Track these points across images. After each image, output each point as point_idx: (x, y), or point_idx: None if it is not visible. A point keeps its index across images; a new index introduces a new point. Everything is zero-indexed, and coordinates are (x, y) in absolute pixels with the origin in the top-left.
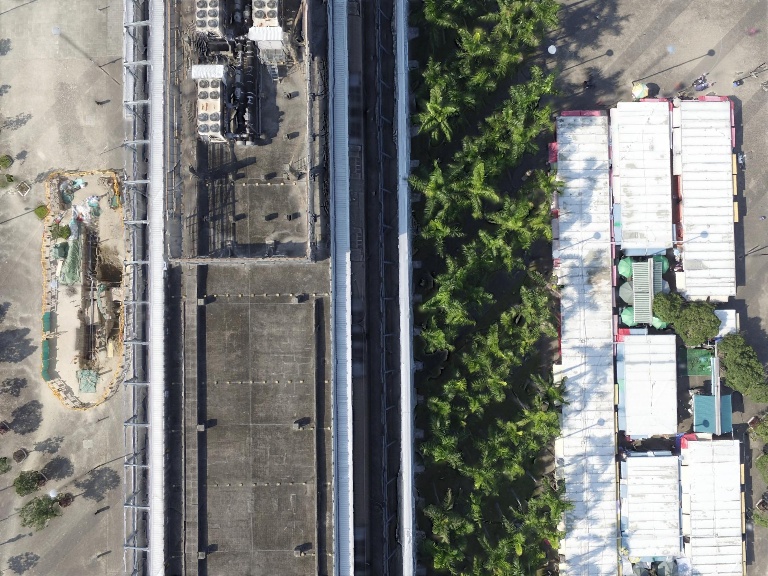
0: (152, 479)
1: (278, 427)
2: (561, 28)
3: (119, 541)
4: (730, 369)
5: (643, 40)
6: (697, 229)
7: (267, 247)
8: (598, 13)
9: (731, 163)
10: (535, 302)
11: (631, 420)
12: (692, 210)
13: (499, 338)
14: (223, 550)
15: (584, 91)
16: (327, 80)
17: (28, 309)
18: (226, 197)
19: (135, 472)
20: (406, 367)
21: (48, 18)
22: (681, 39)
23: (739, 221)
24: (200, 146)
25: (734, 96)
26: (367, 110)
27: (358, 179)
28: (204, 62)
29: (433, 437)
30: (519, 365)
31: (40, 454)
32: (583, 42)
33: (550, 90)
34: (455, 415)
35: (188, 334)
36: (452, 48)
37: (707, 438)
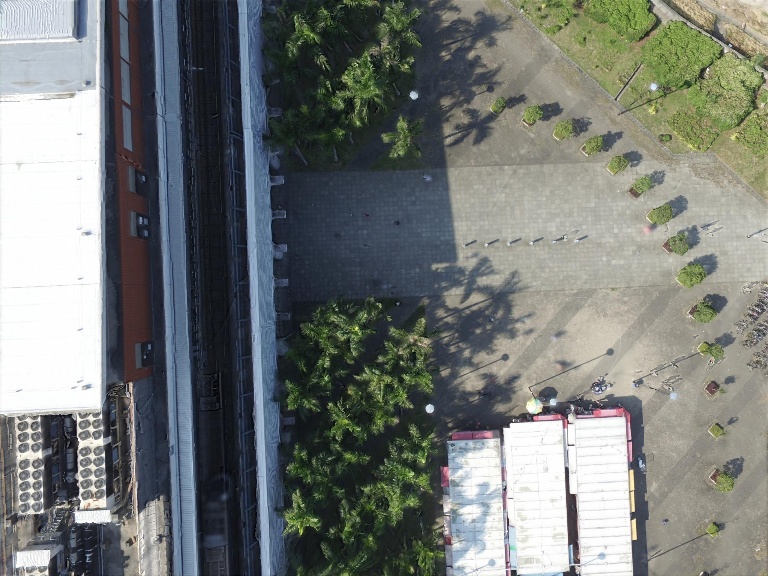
0: None
1: None
2: (454, 333)
3: None
4: None
5: (539, 342)
6: (594, 551)
7: None
8: (492, 316)
9: (628, 481)
10: None
11: None
12: (589, 531)
13: None
14: None
15: (479, 399)
16: (171, 528)
17: None
18: None
19: None
20: None
21: None
22: (579, 339)
23: (641, 526)
24: None
25: (634, 396)
26: (236, 487)
27: None
28: None
29: None
30: None
31: None
32: (477, 347)
33: (429, 449)
34: None
35: None
36: None
37: None
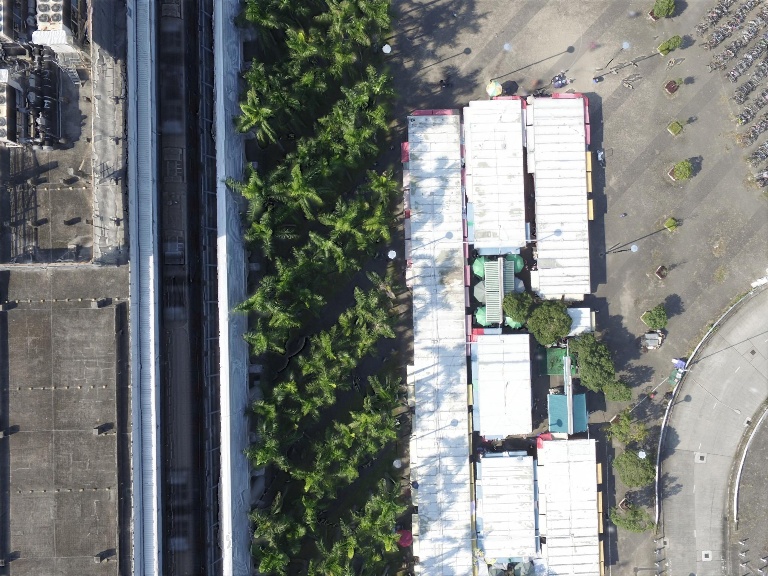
0: None
1: (81, 433)
2: (418, 27)
3: None
4: (582, 368)
5: (501, 38)
6: (551, 227)
7: (69, 252)
8: (456, 11)
9: (585, 160)
10: (366, 303)
11: (485, 420)
12: (545, 208)
13: (335, 340)
14: (26, 557)
15: (442, 90)
16: (126, 83)
17: None
18: (28, 202)
19: None
20: (225, 370)
21: None
22: (540, 36)
23: (600, 219)
24: (1, 151)
25: (594, 93)
26: (197, 112)
27: (179, 182)
28: (5, 67)
29: (259, 440)
30: (353, 367)
31: None
32: (441, 40)
33: (386, 90)
34: (286, 418)
35: None
36: (285, 49)
37: (563, 438)
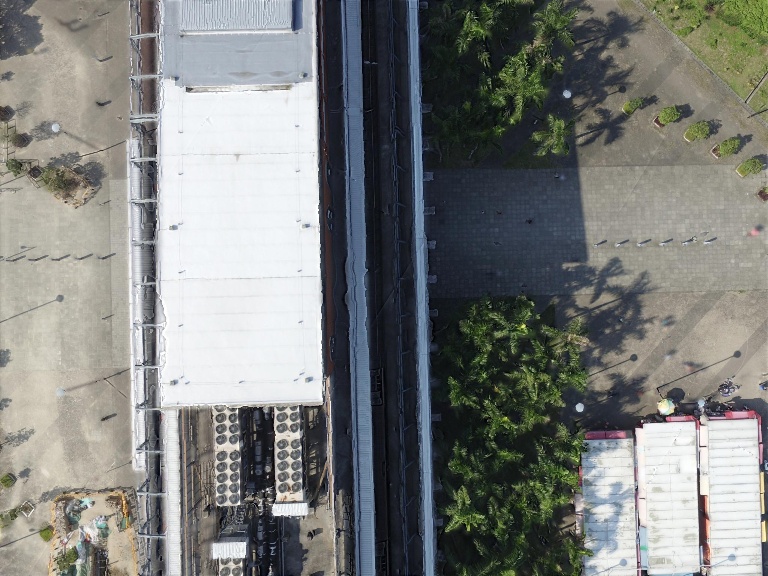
0: None
1: None
2: None
3: None
4: None
5: (668, 343)
6: (724, 552)
7: None
8: (622, 316)
9: (759, 483)
10: None
11: None
12: (719, 533)
13: None
14: None
15: (608, 399)
16: (353, 522)
17: None
18: None
19: None
20: None
21: (49, 327)
22: (706, 341)
23: None
24: None
25: (760, 399)
26: (390, 483)
27: None
28: None
29: None
30: None
31: None
32: (607, 347)
33: None
34: None
35: None
36: (477, 409)
37: None
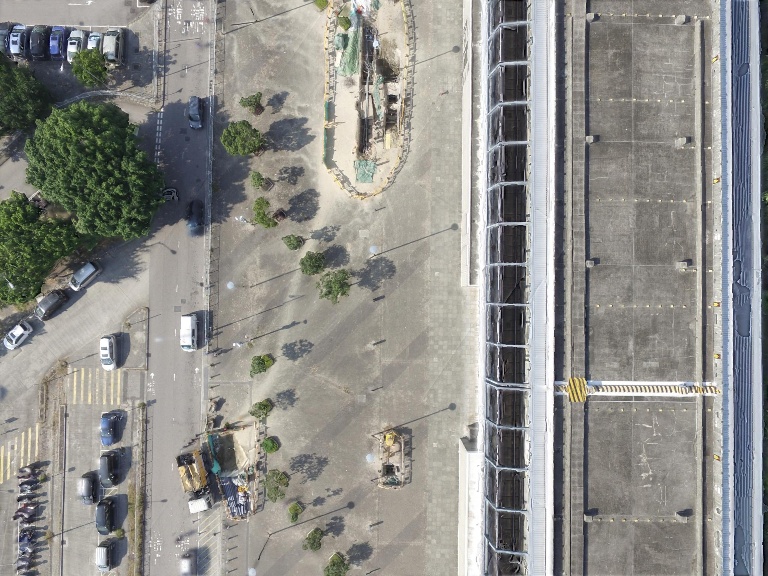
0: (534, 193)
1: (660, 145)
2: None
3: (394, 330)
4: None
5: None
6: None
7: None
8: None
9: None
10: None
11: None
12: None
13: None
14: (605, 263)
15: None
16: None
17: (306, 99)
18: None
19: (488, 206)
20: (756, 112)
21: None
22: None
23: None
24: None
25: None
26: None
27: None
28: None
29: None
30: None
31: (316, 242)
32: None
33: None
34: None
35: (576, 48)
36: None
37: None
